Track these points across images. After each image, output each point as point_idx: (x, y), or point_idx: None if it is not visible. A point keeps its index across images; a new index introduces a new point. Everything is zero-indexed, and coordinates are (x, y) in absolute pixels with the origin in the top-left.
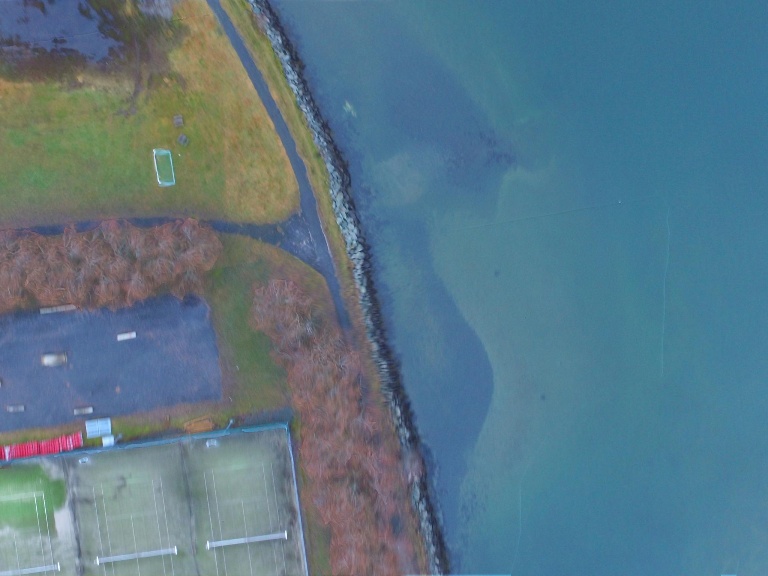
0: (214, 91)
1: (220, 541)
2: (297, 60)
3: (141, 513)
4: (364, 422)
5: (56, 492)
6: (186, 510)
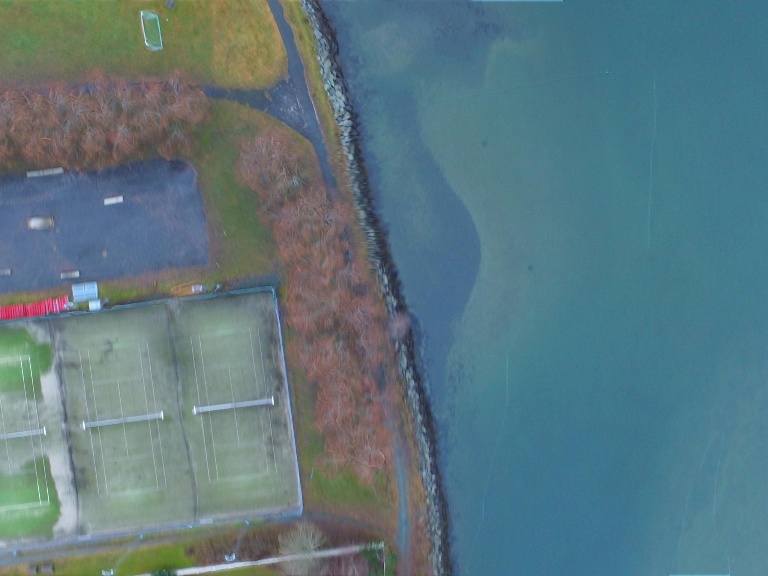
0: None
1: (207, 406)
2: None
3: (127, 378)
4: (350, 273)
5: (42, 356)
6: (173, 375)
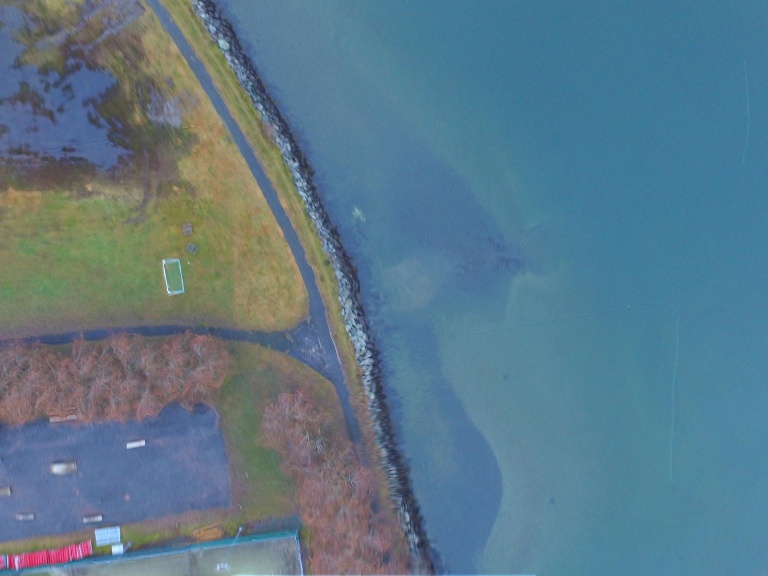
0: (223, 199)
1: None
2: (306, 166)
3: None
4: (374, 541)
5: None
6: None
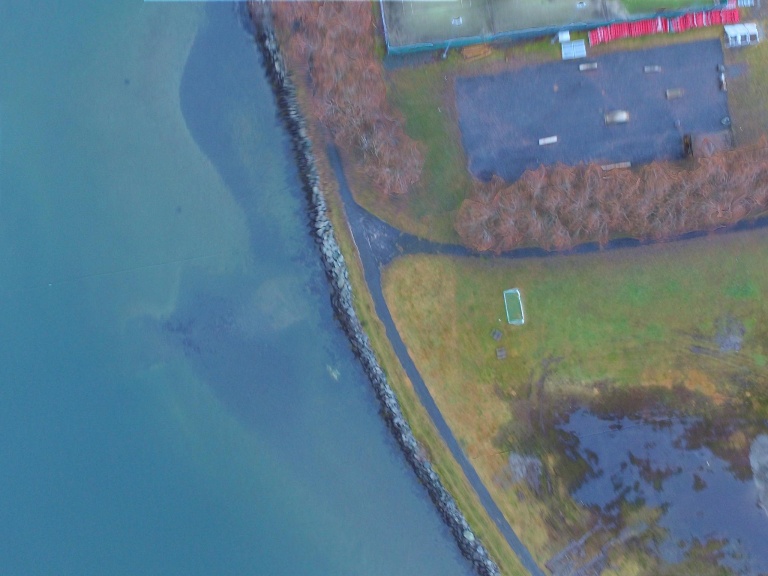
0: (468, 384)
1: None
2: (387, 419)
3: None
4: (307, 45)
5: None
6: None
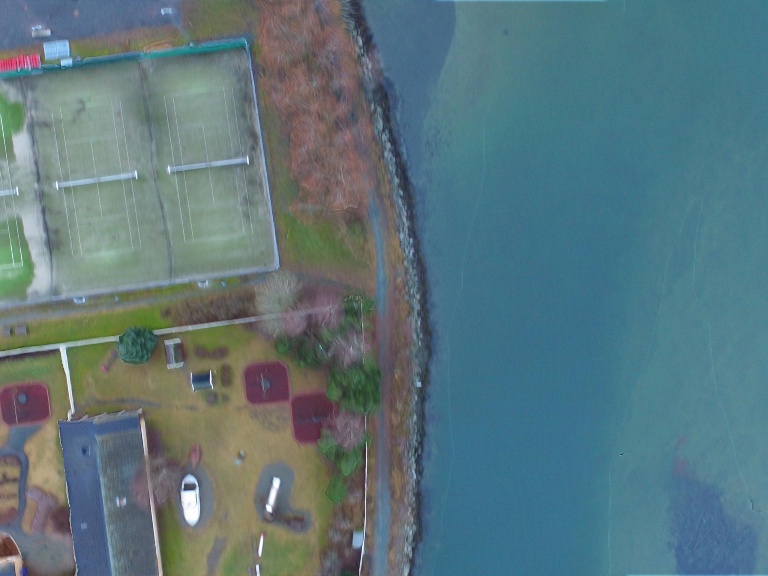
0: None
1: (181, 166)
2: None
3: (101, 137)
4: (321, 4)
5: (14, 115)
6: (146, 134)
